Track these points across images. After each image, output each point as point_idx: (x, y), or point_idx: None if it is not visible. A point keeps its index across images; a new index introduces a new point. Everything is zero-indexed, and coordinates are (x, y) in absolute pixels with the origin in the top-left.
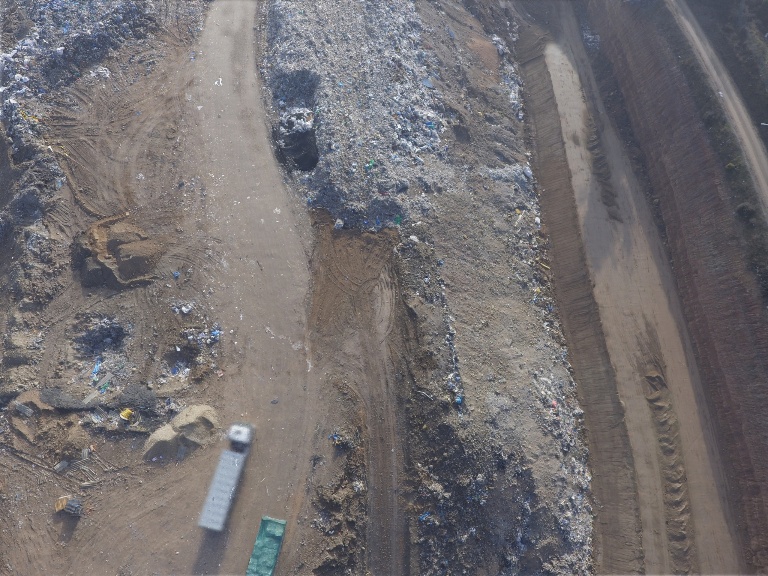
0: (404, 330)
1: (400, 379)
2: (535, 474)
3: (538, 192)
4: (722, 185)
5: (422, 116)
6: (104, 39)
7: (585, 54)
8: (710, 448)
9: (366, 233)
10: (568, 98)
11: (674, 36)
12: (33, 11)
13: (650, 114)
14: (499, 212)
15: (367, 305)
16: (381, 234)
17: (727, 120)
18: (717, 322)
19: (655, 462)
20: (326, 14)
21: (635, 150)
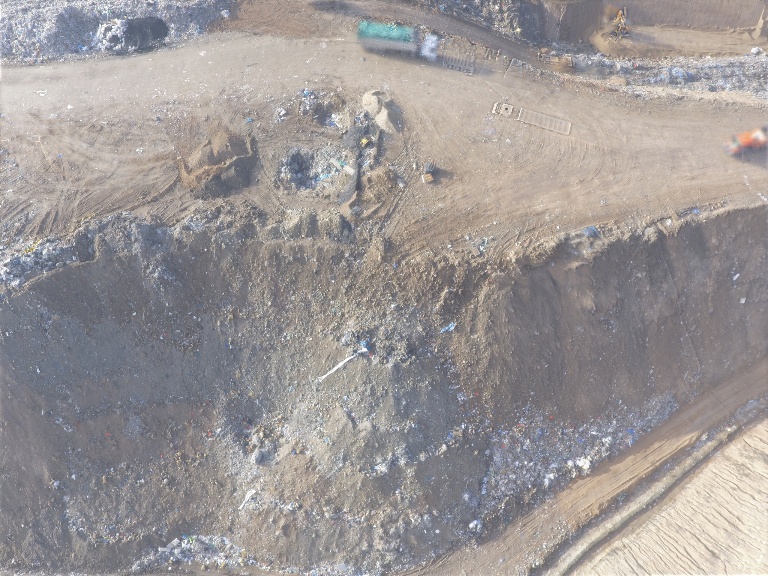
0: None
1: None
2: None
3: None
4: None
5: None
6: None
7: None
8: None
9: None
10: None
11: None
12: None
13: None
14: None
15: (298, 4)
16: None
17: None
18: None
19: None
20: None
21: None
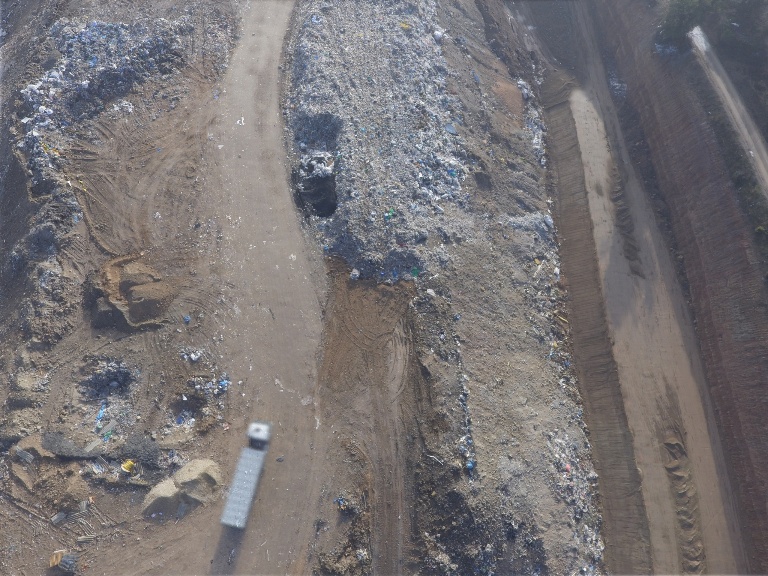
0: (417, 389)
1: (410, 442)
2: (546, 544)
3: (558, 241)
4: (751, 249)
5: (444, 163)
6: (129, 73)
7: (611, 102)
8: (731, 524)
9: (382, 285)
10: (592, 146)
11: (704, 91)
12: (61, 42)
13: (677, 168)
14: (518, 262)
15: (380, 361)
16: (397, 286)
17: (758, 181)
18: (742, 391)
19: (672, 536)
20: (352, 57)
21: (660, 203)
